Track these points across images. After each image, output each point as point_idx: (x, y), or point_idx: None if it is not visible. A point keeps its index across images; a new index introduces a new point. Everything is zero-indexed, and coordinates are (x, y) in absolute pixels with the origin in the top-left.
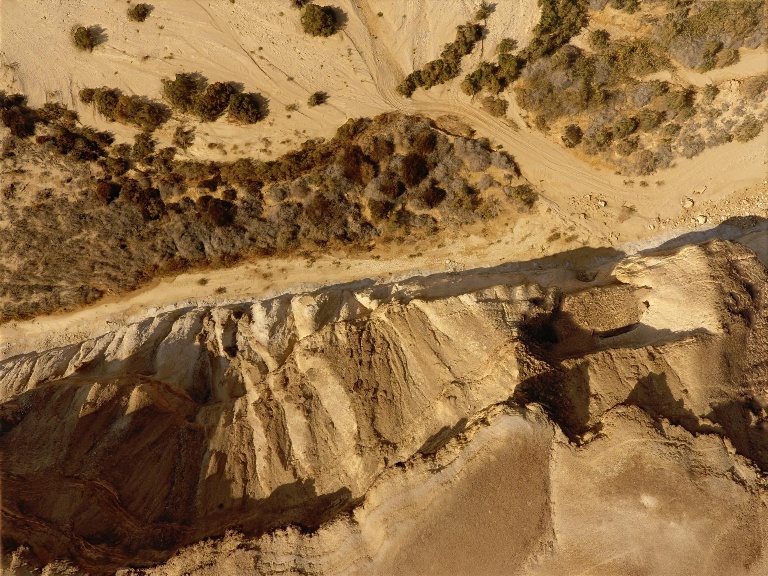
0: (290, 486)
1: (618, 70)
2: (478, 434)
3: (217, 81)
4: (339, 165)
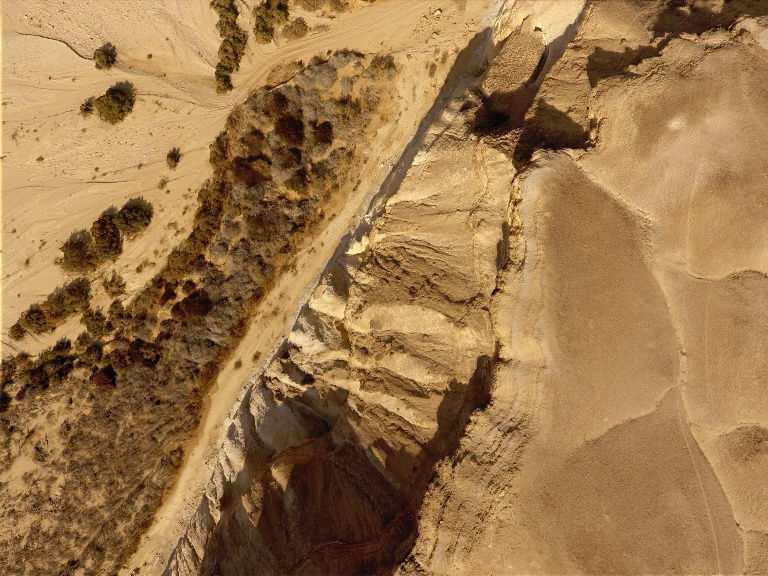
0: (444, 403)
1: None
2: (522, 213)
3: (93, 223)
4: (238, 184)
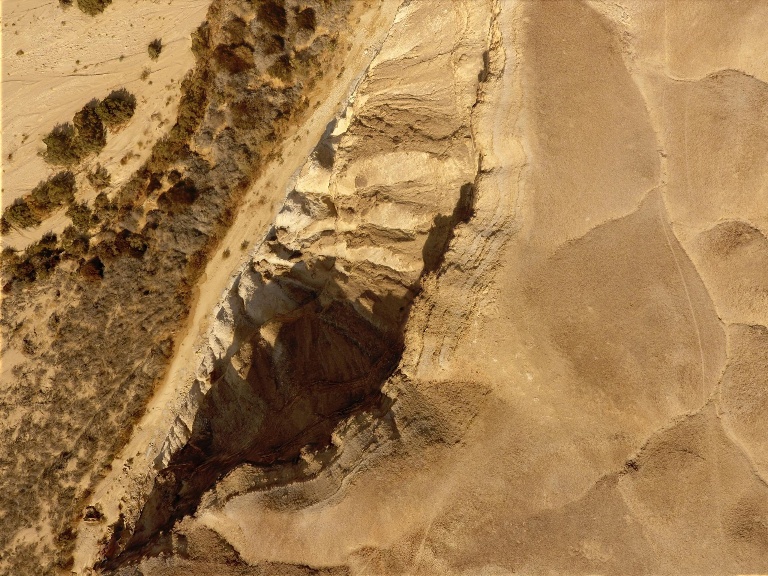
0: (429, 241)
1: None
2: (501, 24)
3: None
4: (221, 71)
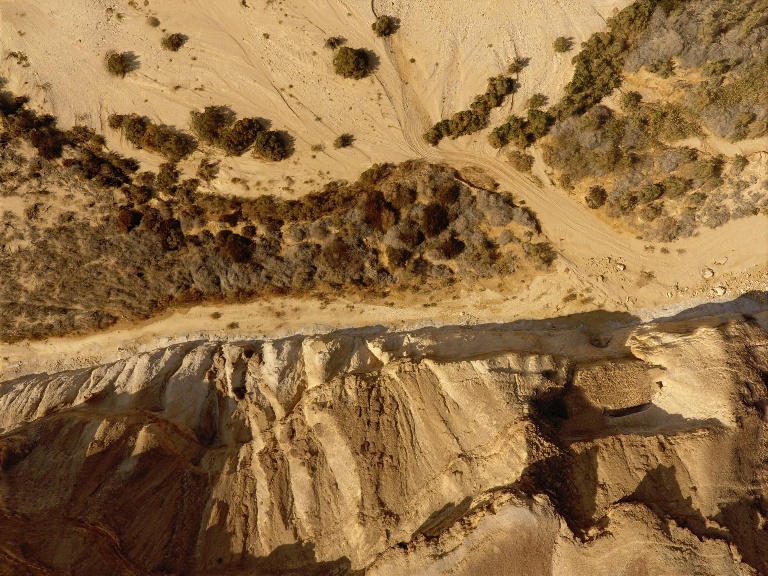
0: (290, 547)
1: (648, 134)
2: (483, 522)
3: (245, 116)
4: (360, 210)
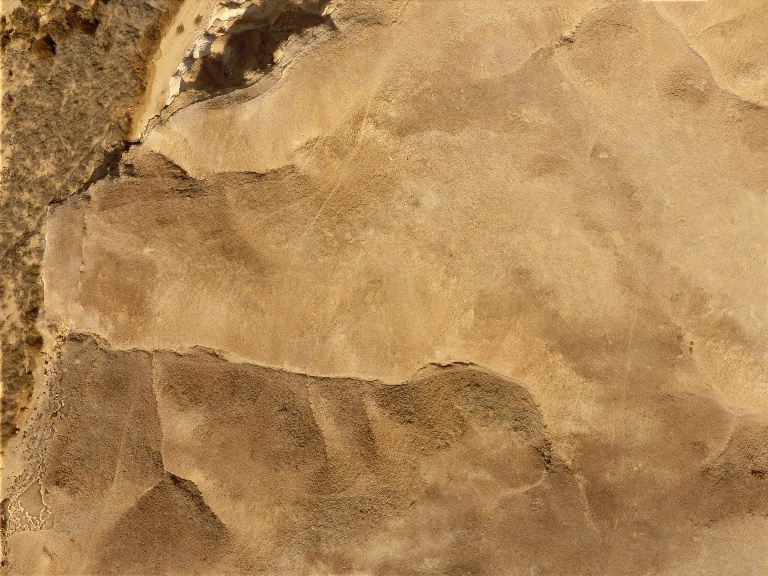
0: None
1: None
2: None
3: None
4: None
